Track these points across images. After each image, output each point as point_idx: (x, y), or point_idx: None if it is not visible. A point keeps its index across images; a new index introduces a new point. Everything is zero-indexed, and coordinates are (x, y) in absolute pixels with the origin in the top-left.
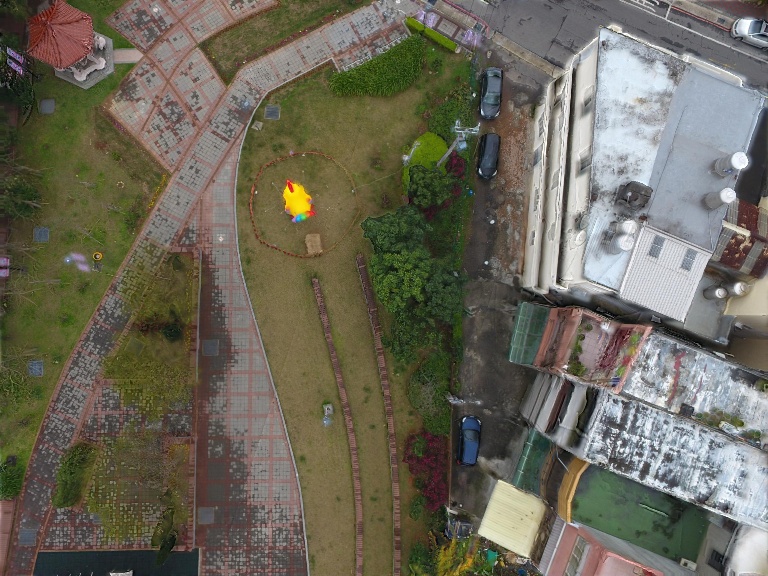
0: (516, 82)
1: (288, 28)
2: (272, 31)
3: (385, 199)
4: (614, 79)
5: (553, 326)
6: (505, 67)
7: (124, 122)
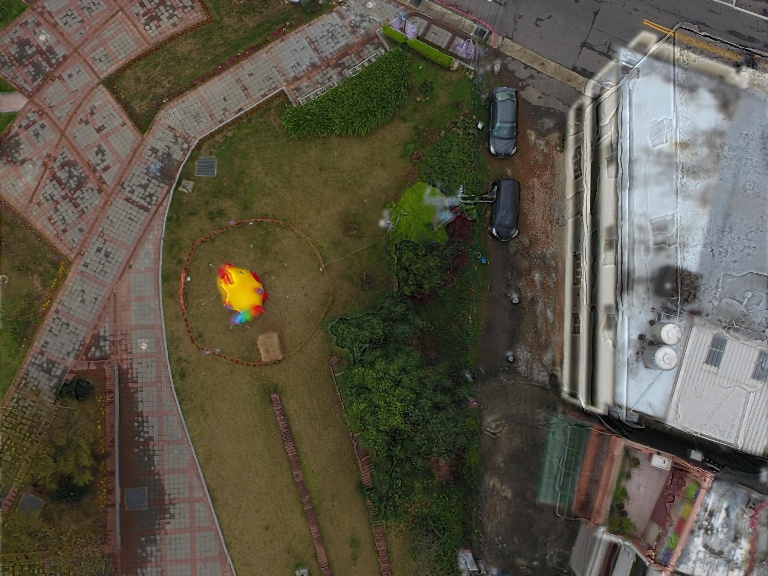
0: (536, 105)
1: (222, 51)
2: (200, 56)
3: (366, 278)
4: (702, 107)
5: (617, 463)
6: (519, 85)
7: (5, 192)
